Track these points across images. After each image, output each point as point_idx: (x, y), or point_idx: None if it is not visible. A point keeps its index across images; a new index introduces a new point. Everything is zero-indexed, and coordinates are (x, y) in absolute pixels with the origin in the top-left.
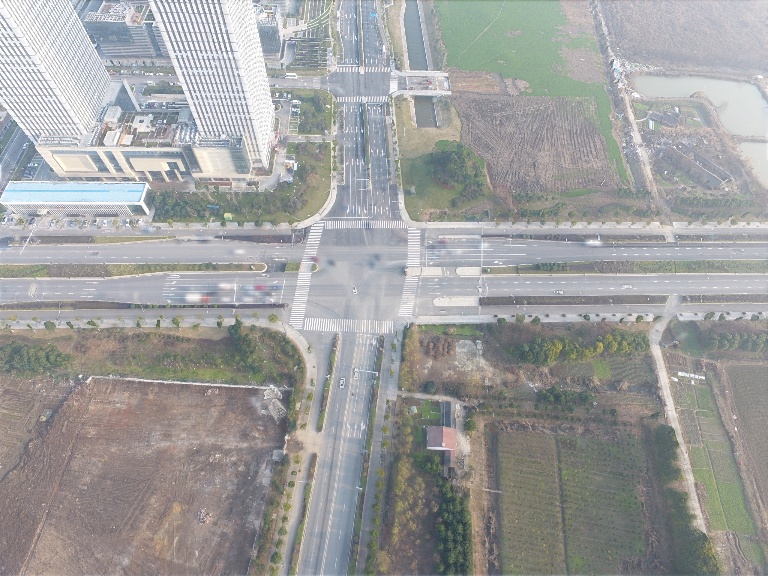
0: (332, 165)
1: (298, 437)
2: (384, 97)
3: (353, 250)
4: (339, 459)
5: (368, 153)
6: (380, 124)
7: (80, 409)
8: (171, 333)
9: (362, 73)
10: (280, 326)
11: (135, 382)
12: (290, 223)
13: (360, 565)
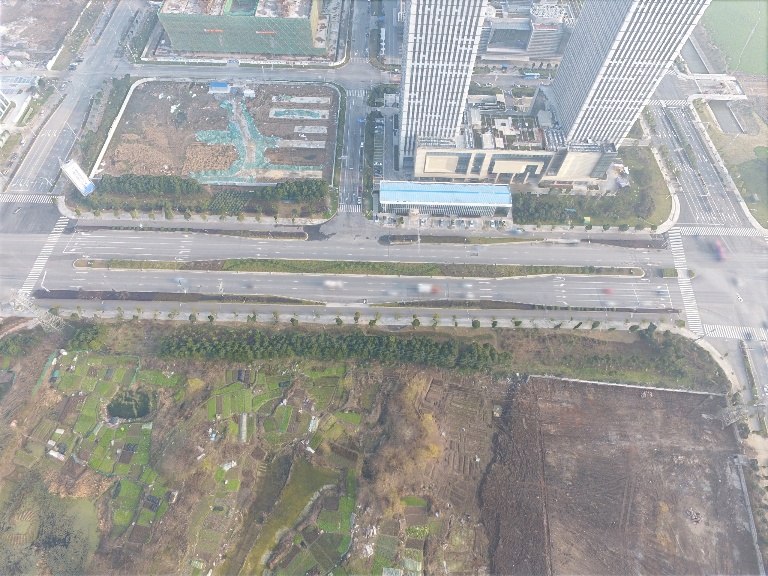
0: (662, 170)
1: (748, 442)
2: (682, 101)
3: (720, 257)
4: None
5: (696, 159)
6: (690, 129)
7: (531, 407)
8: (583, 335)
9: None
10: (683, 331)
11: (570, 382)
12: (654, 228)
13: None
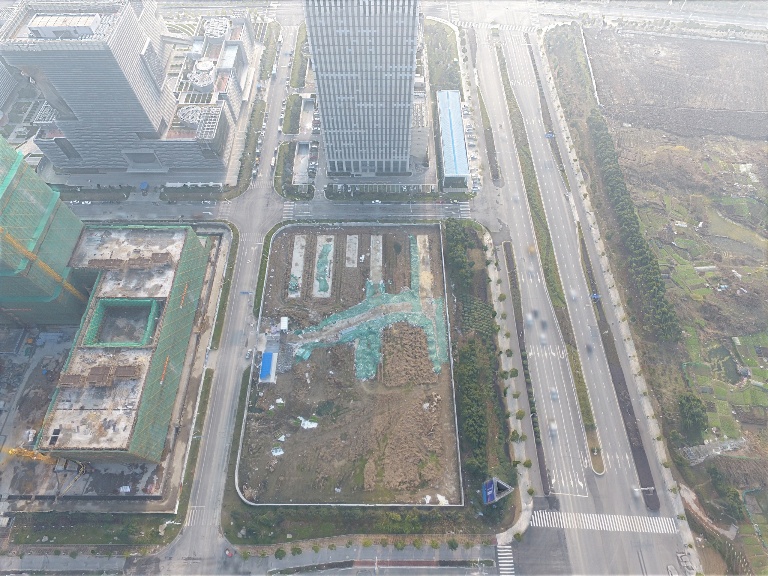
0: None
1: None
2: None
3: (476, 8)
4: (611, 14)
5: None
6: None
7: (620, 107)
8: None
9: (280, 4)
10: None
11: None
12: None
13: (656, 7)
